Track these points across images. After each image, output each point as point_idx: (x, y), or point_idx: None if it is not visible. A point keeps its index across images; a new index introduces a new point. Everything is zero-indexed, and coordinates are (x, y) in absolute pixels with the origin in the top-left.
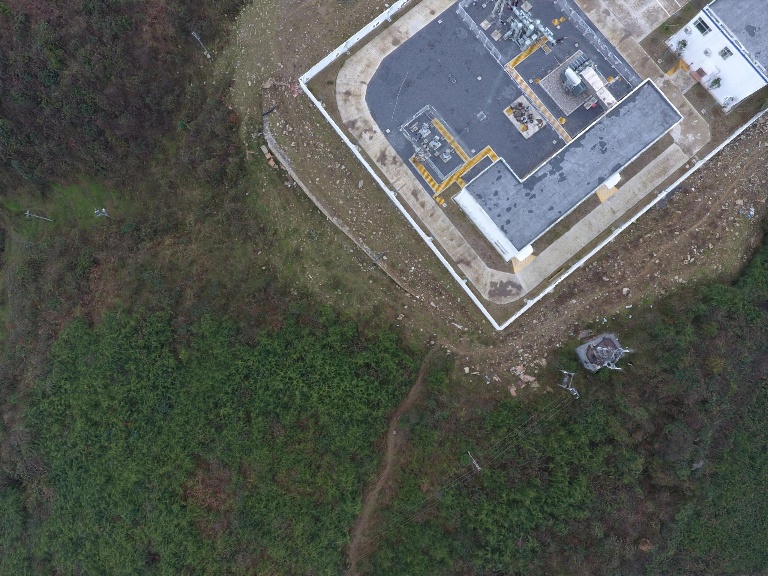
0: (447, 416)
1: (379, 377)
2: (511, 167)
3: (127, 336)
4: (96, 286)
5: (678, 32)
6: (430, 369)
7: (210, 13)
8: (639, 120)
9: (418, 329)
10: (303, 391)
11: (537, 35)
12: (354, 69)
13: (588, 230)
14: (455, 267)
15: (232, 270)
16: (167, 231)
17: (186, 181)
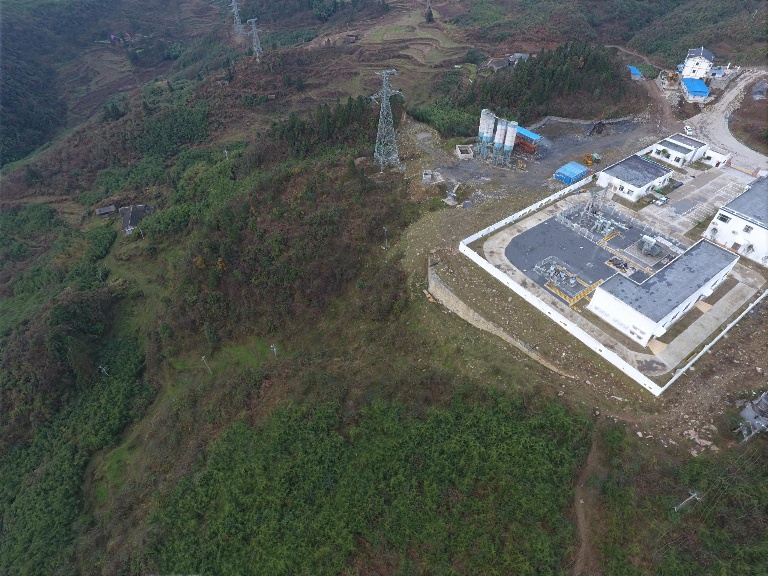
0: (638, 468)
1: (556, 436)
2: None
3: (297, 420)
4: (264, 394)
5: (708, 227)
6: (604, 431)
7: (388, 227)
8: (709, 257)
9: (580, 402)
10: (480, 452)
11: None
12: (494, 242)
13: (702, 329)
14: None
15: None
16: None
17: (352, 325)
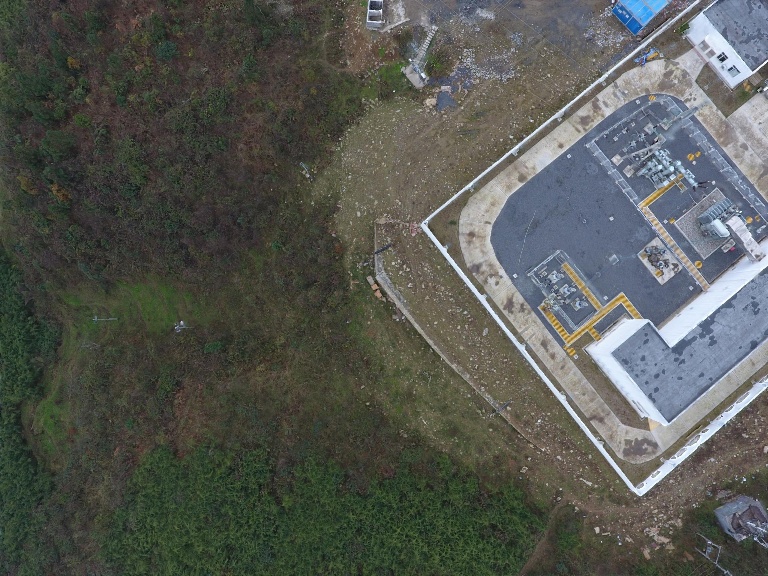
0: None
1: (506, 539)
2: (645, 315)
3: (222, 477)
4: (181, 412)
5: None
6: (559, 530)
7: (311, 132)
8: None
9: (543, 484)
10: (422, 551)
11: (675, 174)
12: (478, 208)
13: (727, 383)
14: (588, 424)
15: (332, 403)
16: (254, 351)
17: (275, 299)
